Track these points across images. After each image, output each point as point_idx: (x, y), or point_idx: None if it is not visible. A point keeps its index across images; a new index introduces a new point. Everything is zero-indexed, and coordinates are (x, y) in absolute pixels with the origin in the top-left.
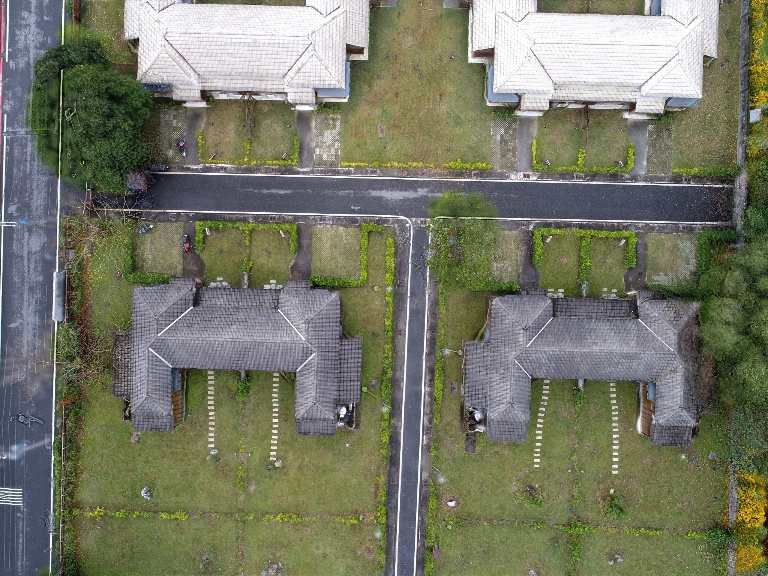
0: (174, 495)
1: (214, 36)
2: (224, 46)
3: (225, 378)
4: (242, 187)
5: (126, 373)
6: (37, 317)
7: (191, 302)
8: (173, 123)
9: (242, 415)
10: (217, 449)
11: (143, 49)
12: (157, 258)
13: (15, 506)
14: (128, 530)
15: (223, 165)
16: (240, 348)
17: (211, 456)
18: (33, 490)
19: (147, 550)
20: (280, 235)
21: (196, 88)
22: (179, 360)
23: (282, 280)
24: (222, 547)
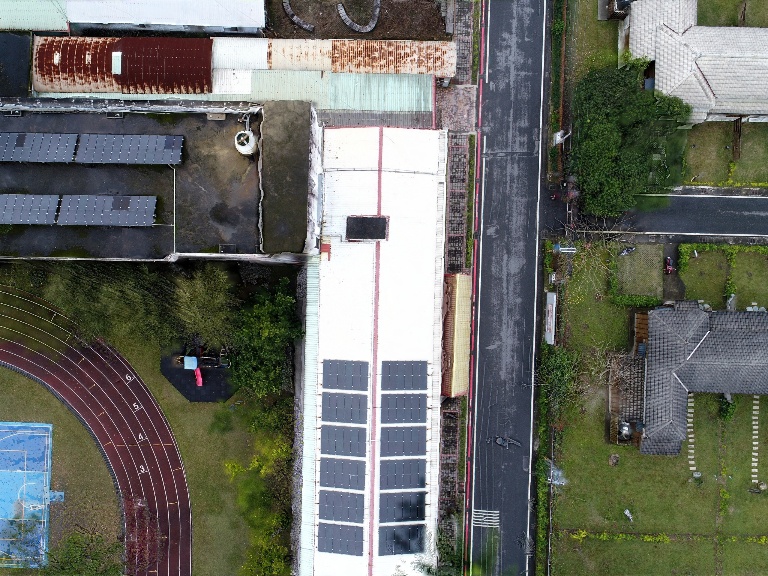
0: (652, 517)
1: (746, 60)
2: (752, 70)
3: (705, 400)
4: (723, 209)
5: (635, 397)
6: (516, 339)
7: (708, 326)
8: (654, 145)
9: (722, 437)
10: (699, 472)
11: (662, 72)
12: (637, 280)
13: (493, 528)
14: (605, 552)
15: (703, 187)
16: (766, 373)
17: (694, 479)
18: (510, 512)
19: (625, 572)
20: (764, 257)
21: (704, 111)
22: (699, 384)
23: (763, 302)
24: (700, 569)
